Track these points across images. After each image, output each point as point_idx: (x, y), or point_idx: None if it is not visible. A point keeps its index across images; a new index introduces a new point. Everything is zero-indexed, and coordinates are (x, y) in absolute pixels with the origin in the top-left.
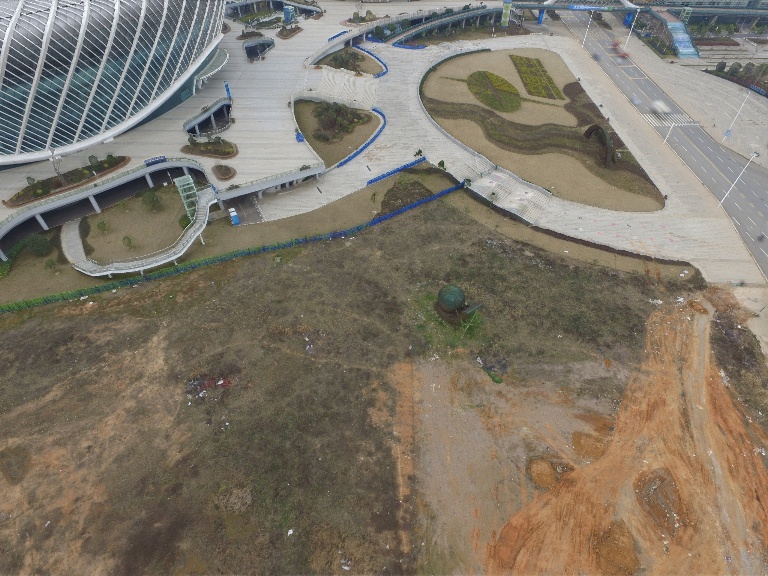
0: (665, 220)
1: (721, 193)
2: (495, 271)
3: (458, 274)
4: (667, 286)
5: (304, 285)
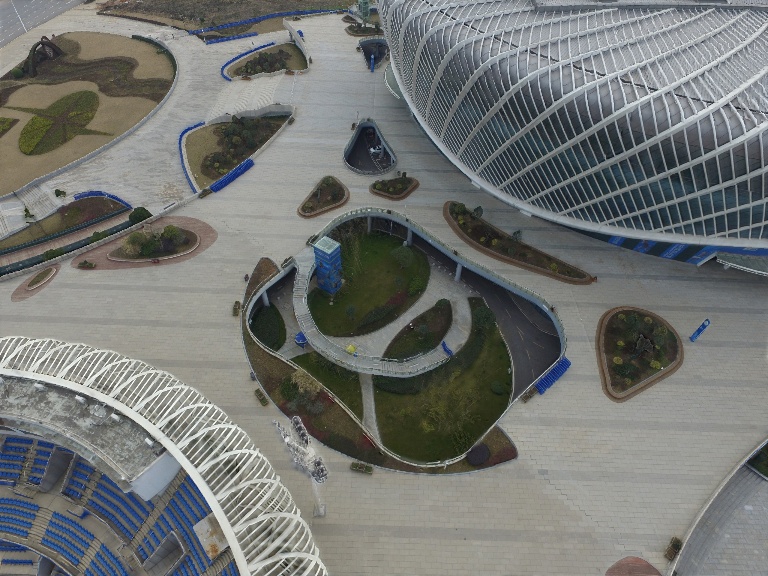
0: (76, 28)
1: (6, 40)
2: (206, 7)
3: (226, 4)
4: (125, 6)
5: (300, 1)
